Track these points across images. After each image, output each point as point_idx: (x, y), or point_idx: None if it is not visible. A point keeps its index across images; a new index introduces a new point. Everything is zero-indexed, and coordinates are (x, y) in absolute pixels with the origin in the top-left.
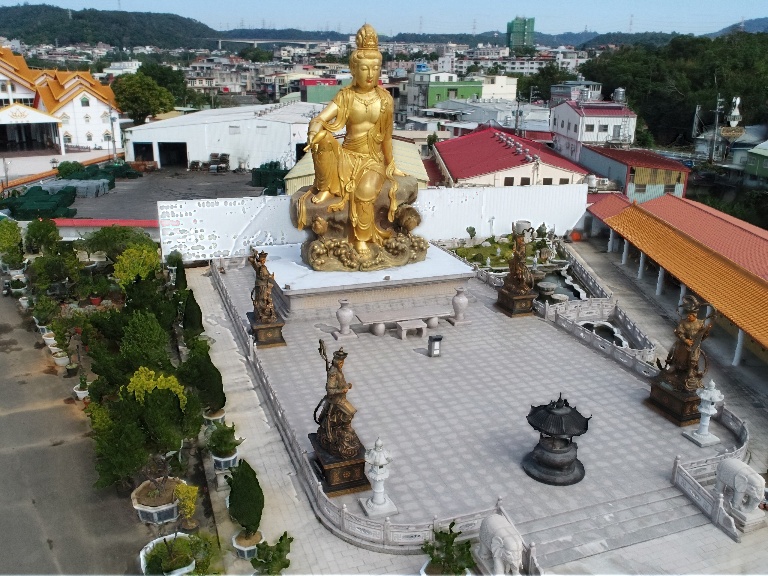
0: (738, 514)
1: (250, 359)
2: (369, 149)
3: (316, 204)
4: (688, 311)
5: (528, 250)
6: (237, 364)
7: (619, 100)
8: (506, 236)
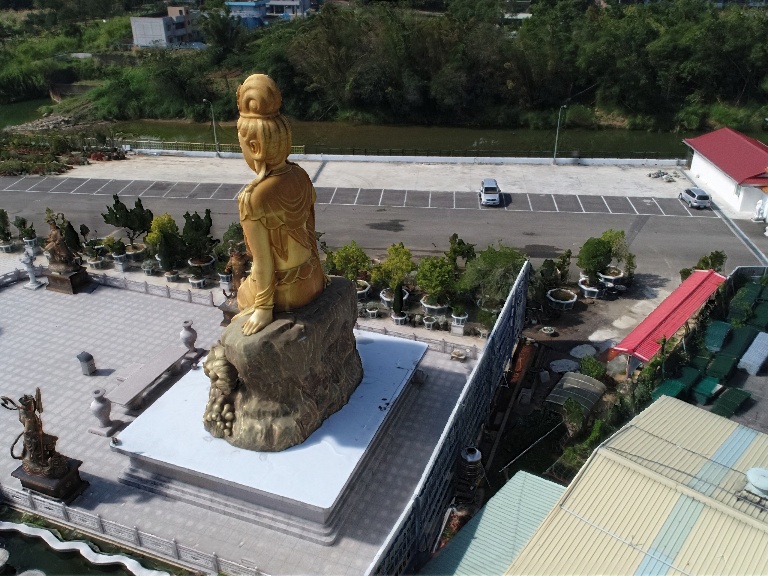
0: None
1: None
2: None
3: None
4: None
5: None
6: None
7: None
8: None
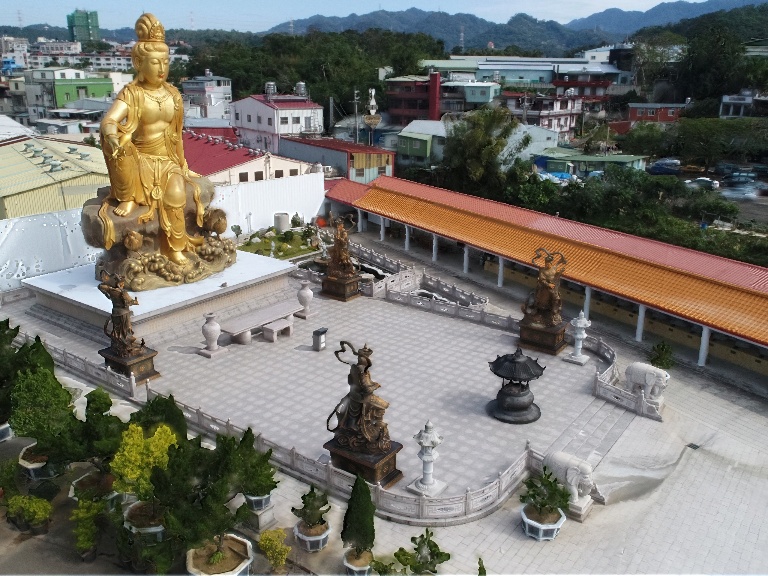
0: (651, 402)
1: (136, 400)
2: (167, 151)
3: (124, 217)
4: (547, 261)
5: (298, 240)
6: (124, 409)
7: (302, 93)
8: (268, 230)
